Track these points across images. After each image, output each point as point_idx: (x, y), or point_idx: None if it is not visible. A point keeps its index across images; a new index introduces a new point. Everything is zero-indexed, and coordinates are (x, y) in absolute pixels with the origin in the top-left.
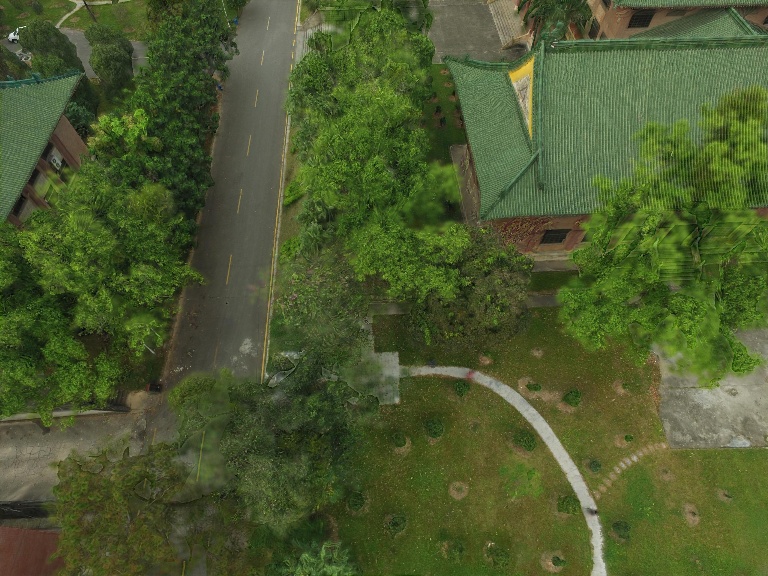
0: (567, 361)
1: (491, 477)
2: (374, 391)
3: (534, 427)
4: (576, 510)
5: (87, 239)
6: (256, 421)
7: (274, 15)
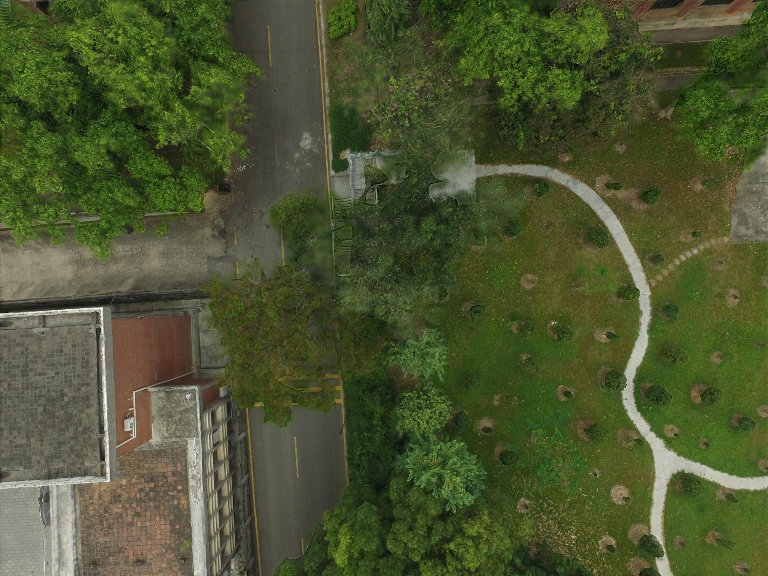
0: (650, 156)
1: (560, 270)
2: (450, 192)
3: (606, 224)
4: (635, 297)
5: (144, 37)
6: (378, 245)
7: None
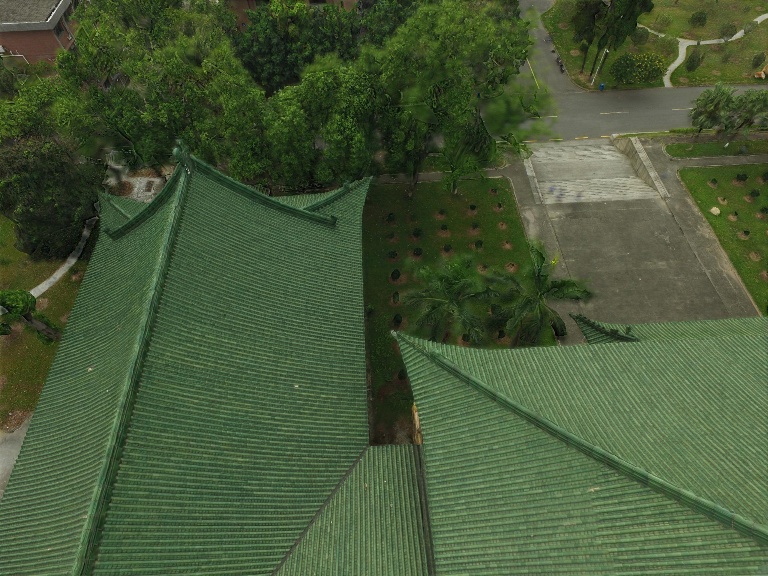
0: None
1: None
2: None
3: None
4: None
5: None
6: None
7: (636, 115)
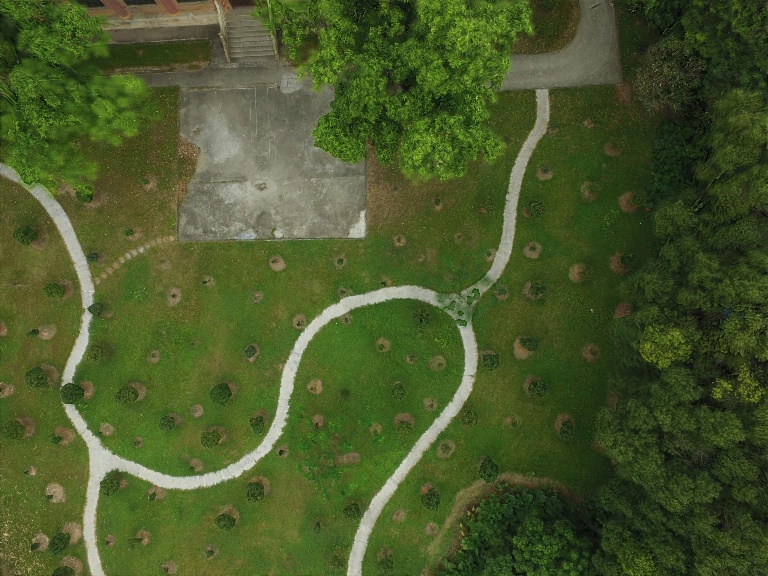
0: (103, 154)
1: (6, 266)
2: None
3: (54, 222)
4: None
5: None
6: None
7: None
